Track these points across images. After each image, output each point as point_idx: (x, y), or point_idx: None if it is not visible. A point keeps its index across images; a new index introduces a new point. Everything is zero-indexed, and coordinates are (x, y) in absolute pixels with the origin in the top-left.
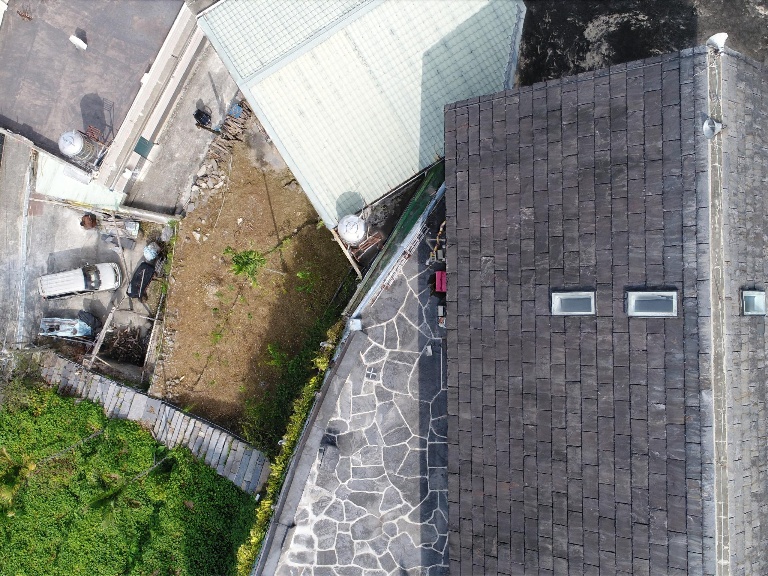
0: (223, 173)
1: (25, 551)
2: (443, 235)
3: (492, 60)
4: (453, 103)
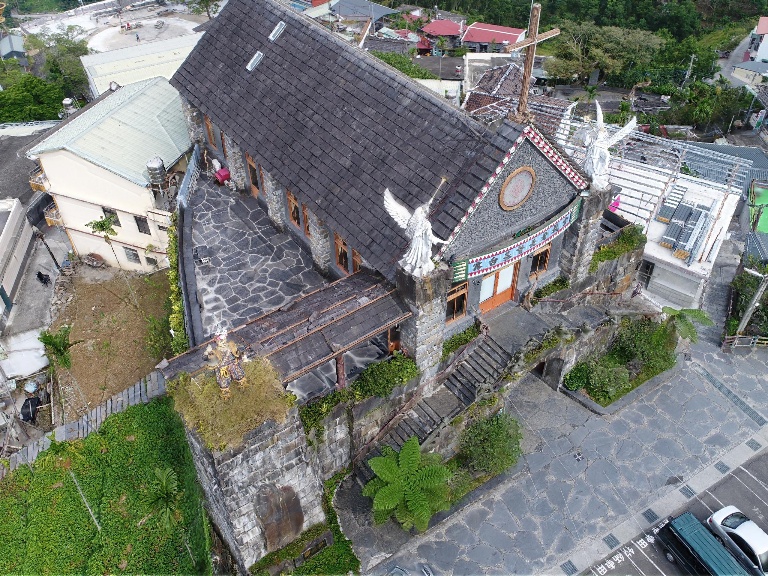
0: (70, 294)
1: None
2: (210, 168)
3: None
4: None
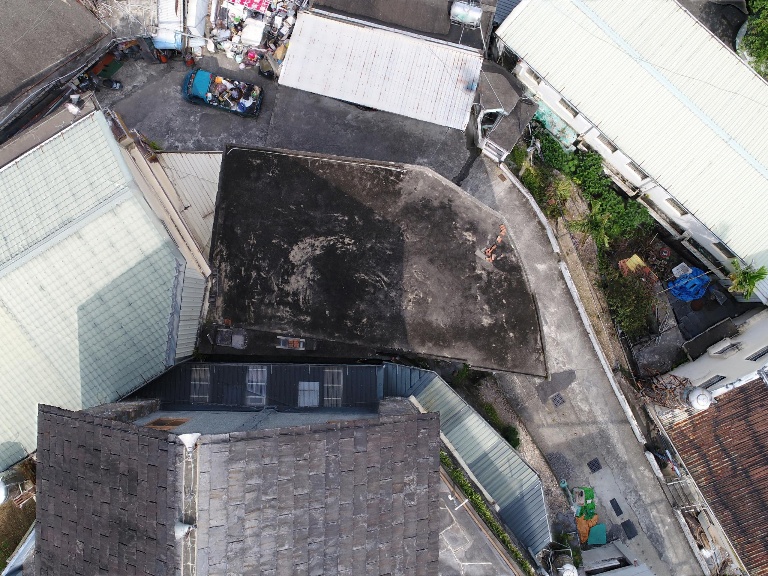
0: None
1: None
2: None
3: (153, 312)
4: (43, 405)
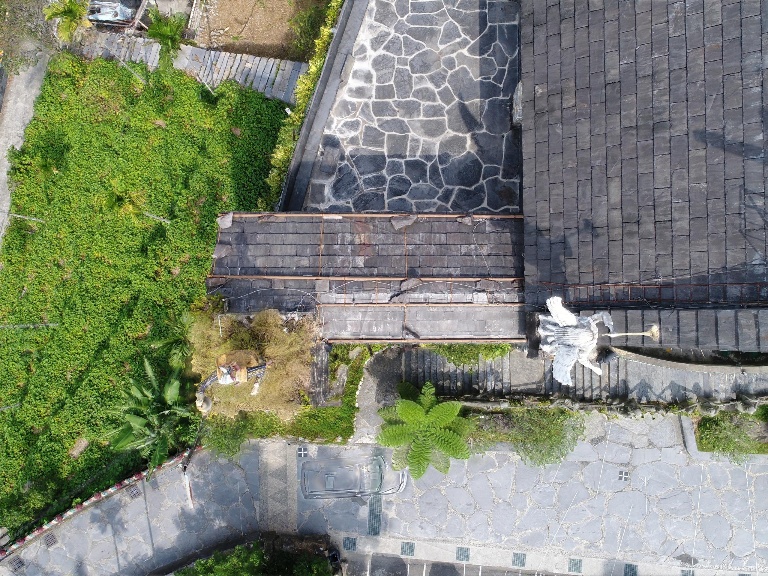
0: None
1: (68, 207)
2: None
3: None
4: None
